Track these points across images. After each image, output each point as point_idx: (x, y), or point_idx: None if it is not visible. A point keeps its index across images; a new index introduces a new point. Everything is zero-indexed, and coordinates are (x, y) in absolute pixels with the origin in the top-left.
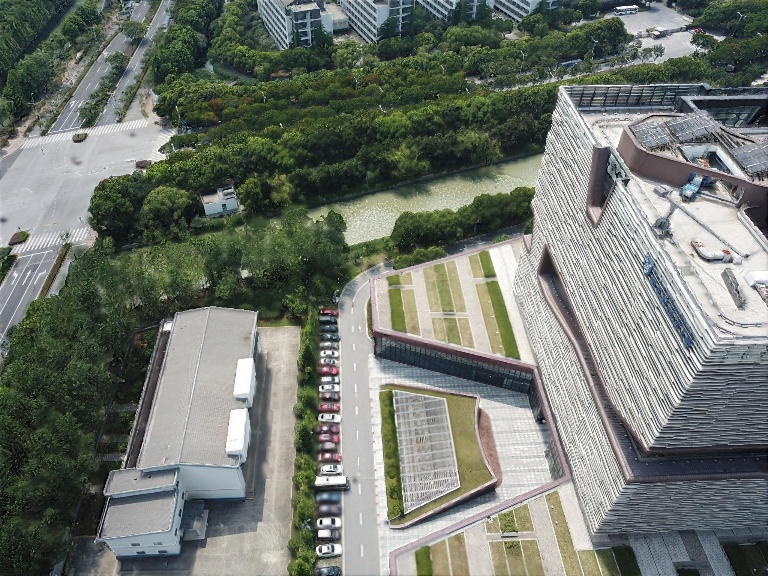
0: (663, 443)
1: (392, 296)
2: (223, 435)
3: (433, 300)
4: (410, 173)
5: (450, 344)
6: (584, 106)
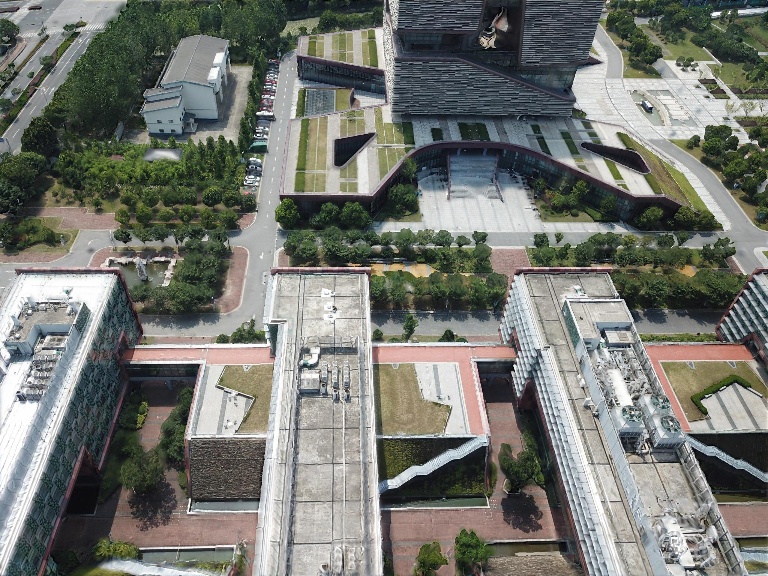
0: (402, 24)
1: (310, 43)
2: (206, 77)
3: (335, 46)
4: (337, 3)
5: (340, 61)
6: None
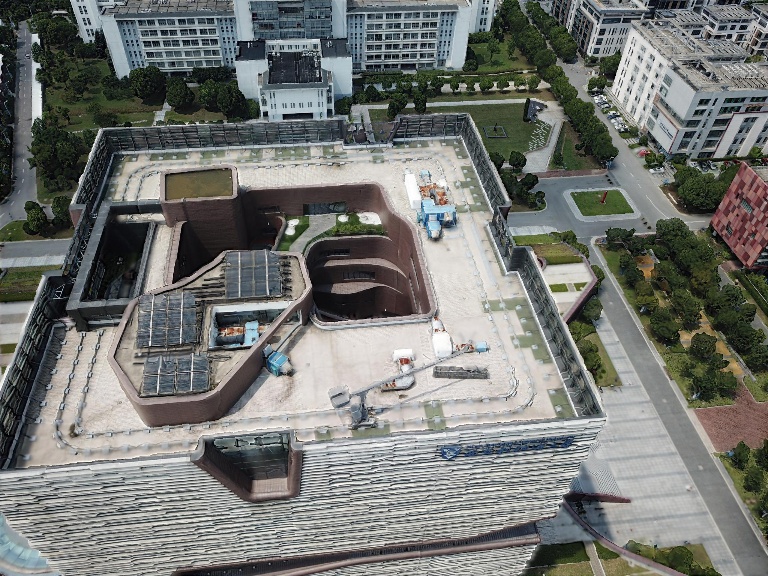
0: None
1: None
2: None
3: None
4: None
5: None
6: (6, 448)
